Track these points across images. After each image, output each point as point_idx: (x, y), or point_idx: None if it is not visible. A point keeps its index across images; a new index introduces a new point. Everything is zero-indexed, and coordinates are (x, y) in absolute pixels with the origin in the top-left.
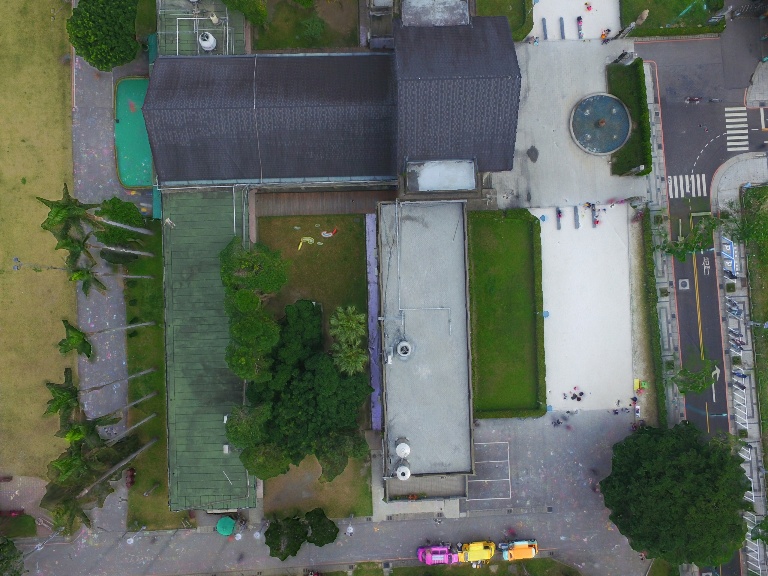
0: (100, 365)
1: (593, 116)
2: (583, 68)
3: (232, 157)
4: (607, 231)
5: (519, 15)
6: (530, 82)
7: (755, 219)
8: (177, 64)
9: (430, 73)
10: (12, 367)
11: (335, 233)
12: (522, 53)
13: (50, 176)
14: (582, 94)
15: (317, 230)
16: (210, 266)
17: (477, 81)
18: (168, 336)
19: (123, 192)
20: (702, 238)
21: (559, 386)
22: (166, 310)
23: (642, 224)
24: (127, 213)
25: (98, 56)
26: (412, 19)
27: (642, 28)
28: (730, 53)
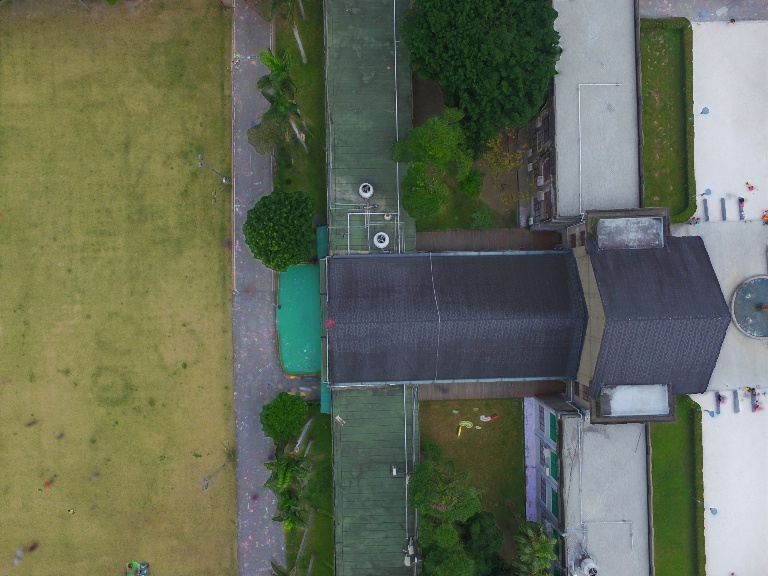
0: (259, 551)
1: (754, 299)
2: (744, 249)
3: (409, 362)
4: (766, 415)
5: (680, 195)
6: None
7: None
8: (353, 265)
9: (638, 312)
10: (173, 554)
11: None
12: (683, 234)
13: (210, 360)
14: (743, 276)
15: (475, 414)
16: (380, 464)
17: (686, 321)
18: (337, 534)
19: (282, 376)
20: None
21: (717, 572)
22: (335, 508)
23: None
24: (296, 410)
25: (279, 263)
26: (605, 239)
27: None
28: None
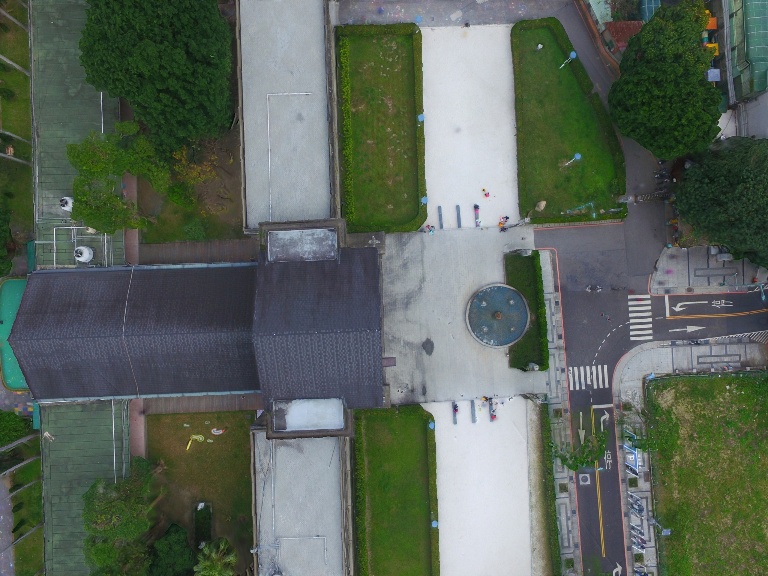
0: None
1: (490, 307)
2: (480, 257)
3: (106, 378)
4: (505, 424)
5: (414, 203)
6: (425, 272)
7: (657, 414)
8: (51, 280)
9: (287, 327)
10: None
11: (225, 431)
12: (417, 242)
13: None
14: (479, 284)
15: (207, 427)
16: (89, 480)
17: (335, 335)
18: (47, 552)
19: (9, 391)
20: (591, 455)
21: None
22: (45, 525)
23: (541, 419)
24: (6, 426)
25: None
26: (279, 251)
27: (541, 216)
28: (634, 238)
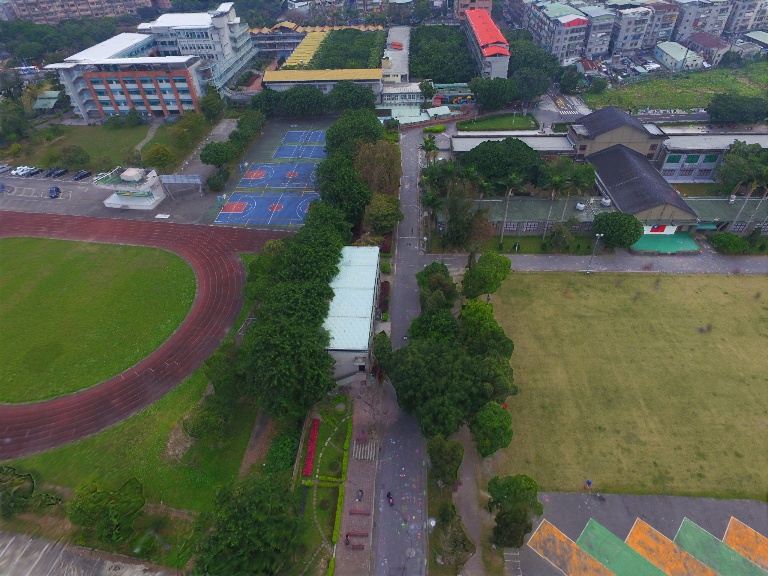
0: None
1: None
2: None
3: None
4: None
5: None
6: None
7: None
8: None
9: None
10: None
11: None
12: None
13: None
14: None
15: None
16: None
17: None
18: None
19: None
20: None
21: None
22: None
23: None
24: None
25: None
26: None
27: None
28: None
